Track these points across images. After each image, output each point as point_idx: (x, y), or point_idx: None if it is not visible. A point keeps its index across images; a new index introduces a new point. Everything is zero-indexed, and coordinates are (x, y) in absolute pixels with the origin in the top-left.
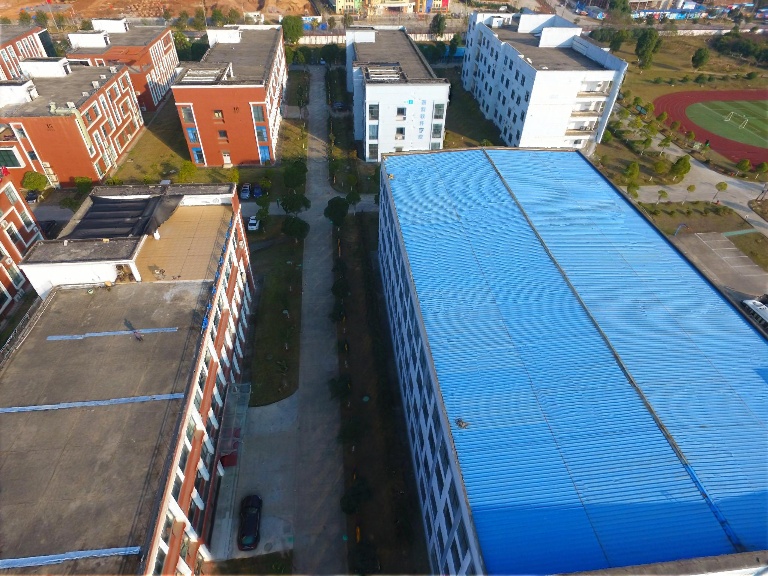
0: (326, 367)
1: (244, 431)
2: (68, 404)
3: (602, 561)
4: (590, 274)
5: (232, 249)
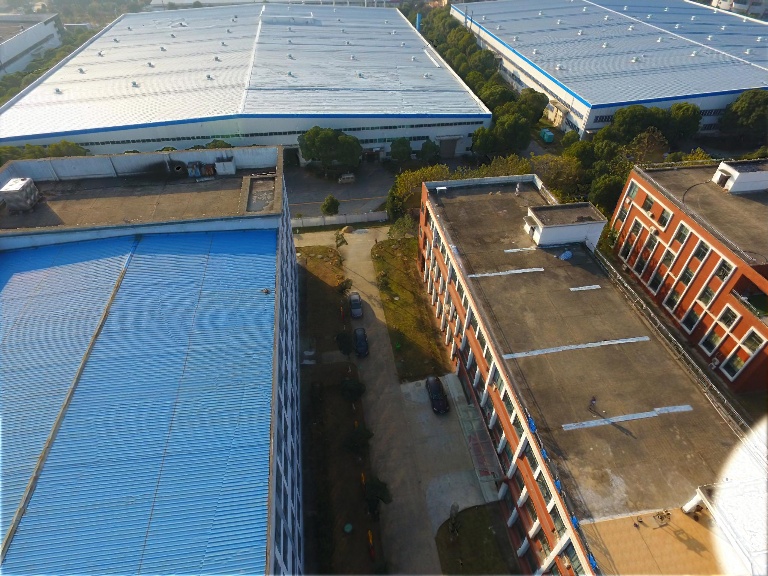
0: None
1: None
2: (593, 345)
3: (216, 237)
4: (2, 458)
5: None
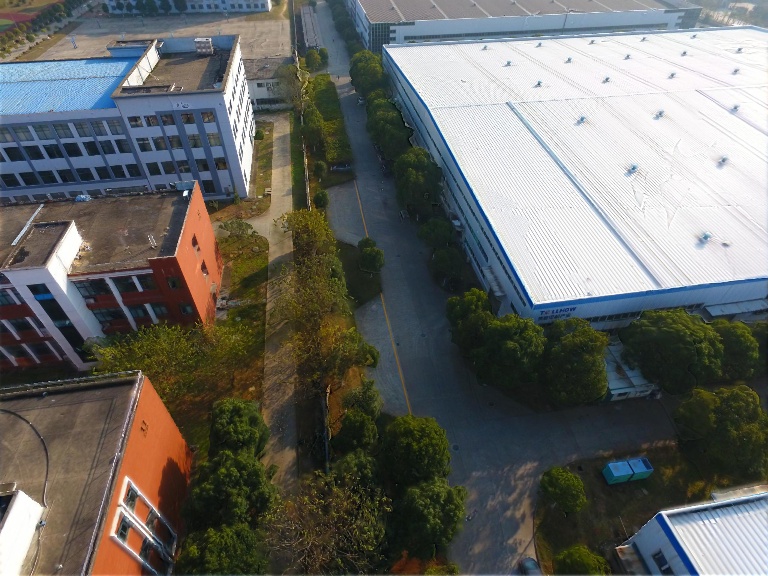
0: None
1: None
2: None
3: None
4: None
5: None
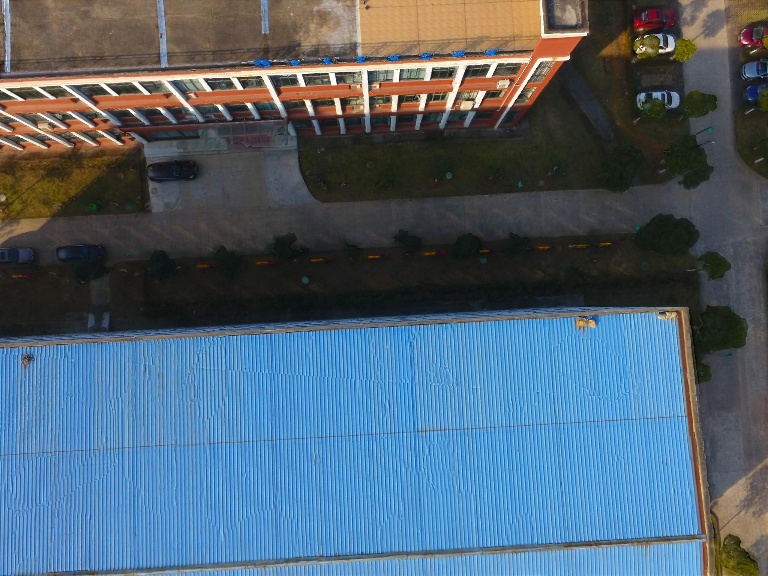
0: (352, 233)
1: (267, 151)
2: None
3: None
4: None
5: (460, 70)
